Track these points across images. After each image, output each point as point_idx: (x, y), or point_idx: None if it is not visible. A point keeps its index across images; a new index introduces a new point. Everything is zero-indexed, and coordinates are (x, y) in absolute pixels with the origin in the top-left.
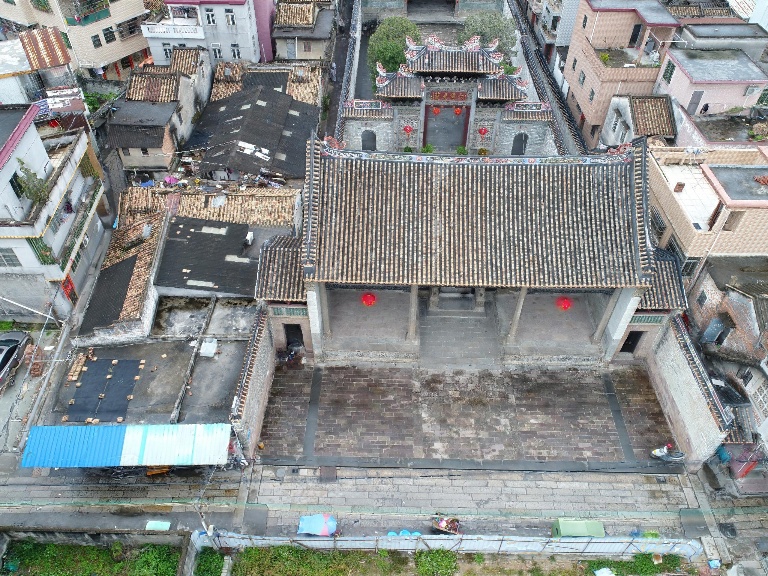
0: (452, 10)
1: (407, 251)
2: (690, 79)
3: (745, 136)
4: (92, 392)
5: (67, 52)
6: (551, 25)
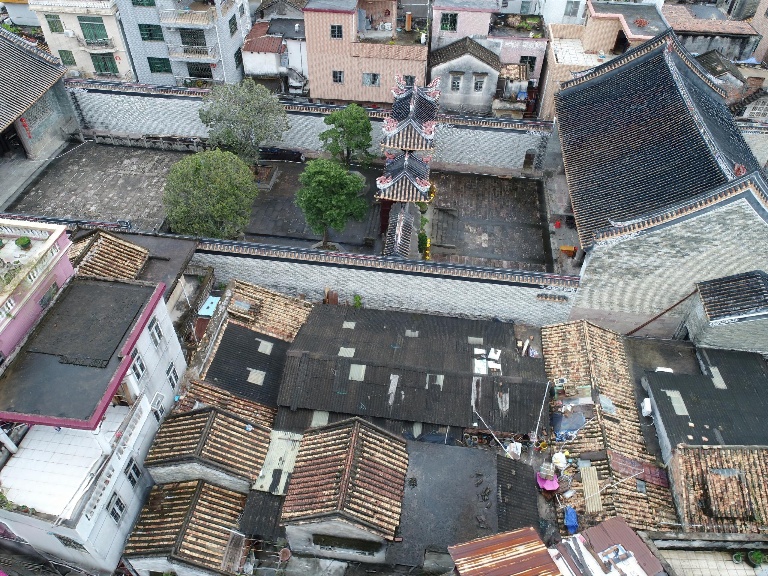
0: (7, 157)
1: None
2: (493, 11)
3: (517, 30)
4: None
5: (513, 533)
6: (190, 80)
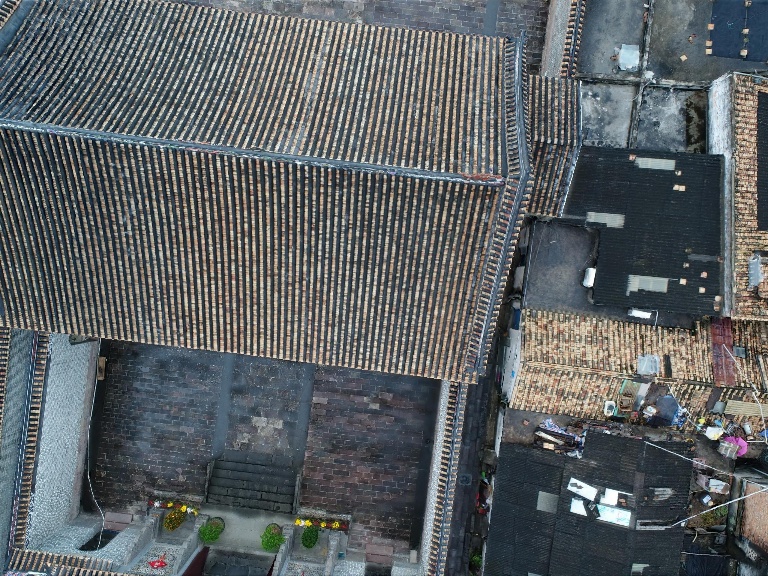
0: None
1: (366, 60)
2: None
3: None
4: (761, 10)
5: None
6: None
